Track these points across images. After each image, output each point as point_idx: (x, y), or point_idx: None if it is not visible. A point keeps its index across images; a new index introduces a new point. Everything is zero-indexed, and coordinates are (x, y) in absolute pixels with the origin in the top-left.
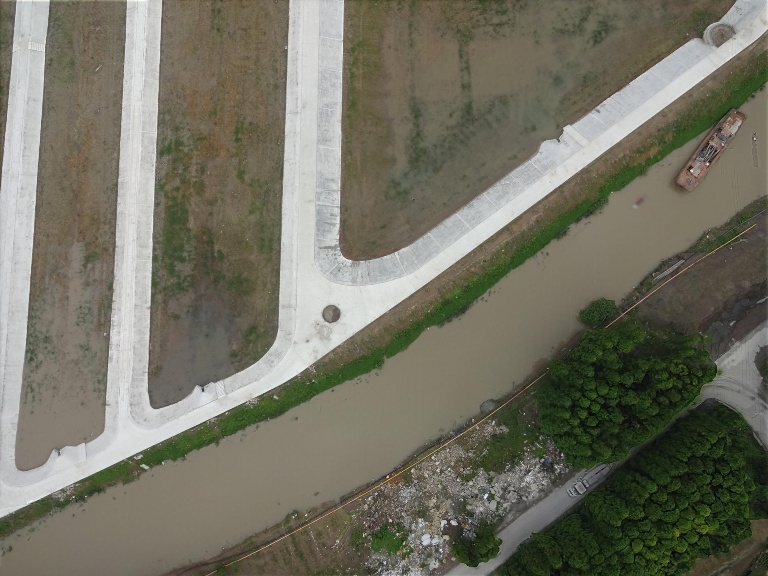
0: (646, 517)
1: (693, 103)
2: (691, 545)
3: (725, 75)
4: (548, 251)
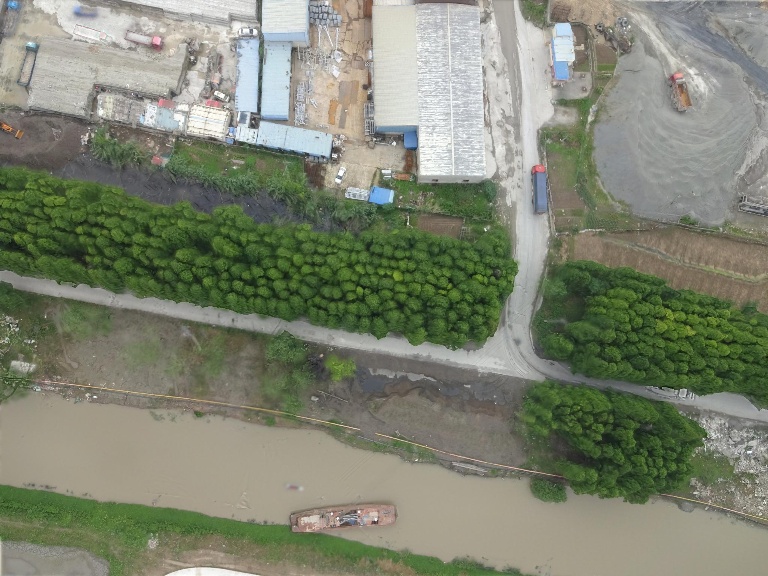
0: (707, 366)
1: (322, 572)
2: (686, 313)
3: (275, 567)
4: (534, 569)
